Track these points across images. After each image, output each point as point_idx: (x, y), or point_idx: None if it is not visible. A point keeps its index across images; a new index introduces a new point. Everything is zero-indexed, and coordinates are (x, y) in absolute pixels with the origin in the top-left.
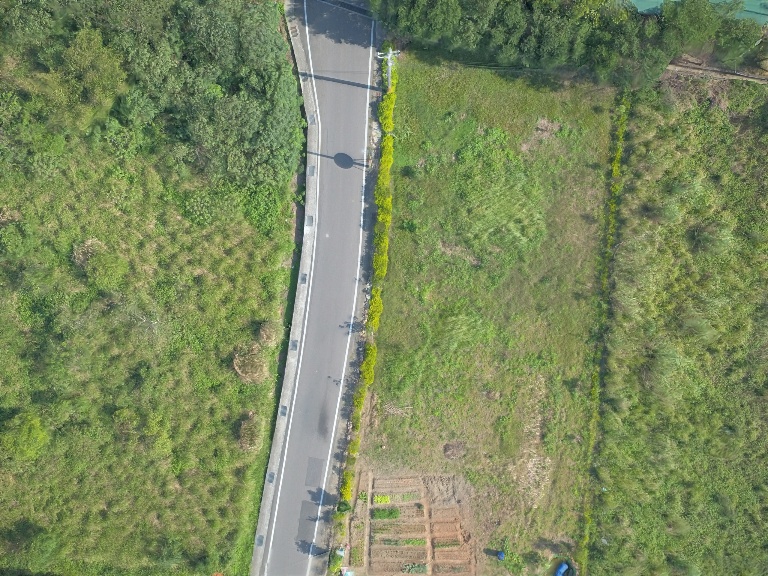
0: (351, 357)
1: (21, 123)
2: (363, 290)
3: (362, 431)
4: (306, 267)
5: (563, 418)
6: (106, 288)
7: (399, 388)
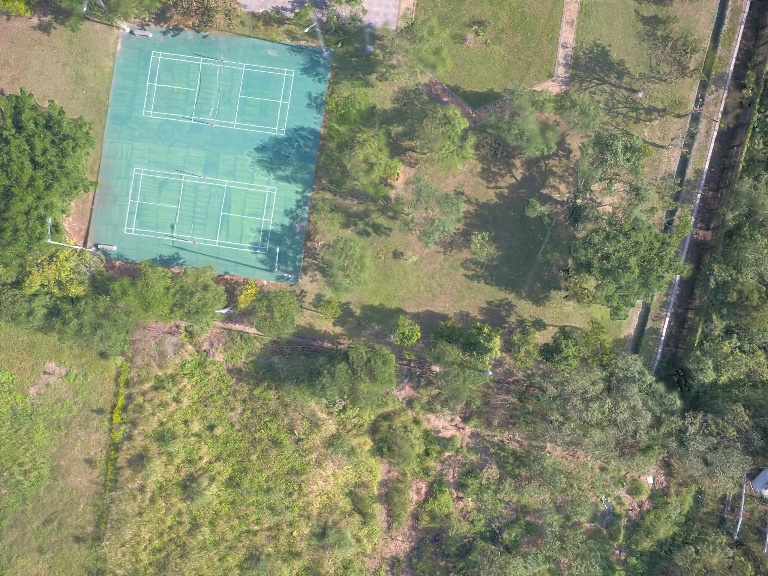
0: None
1: None
2: None
3: None
4: None
5: None
6: None
7: None
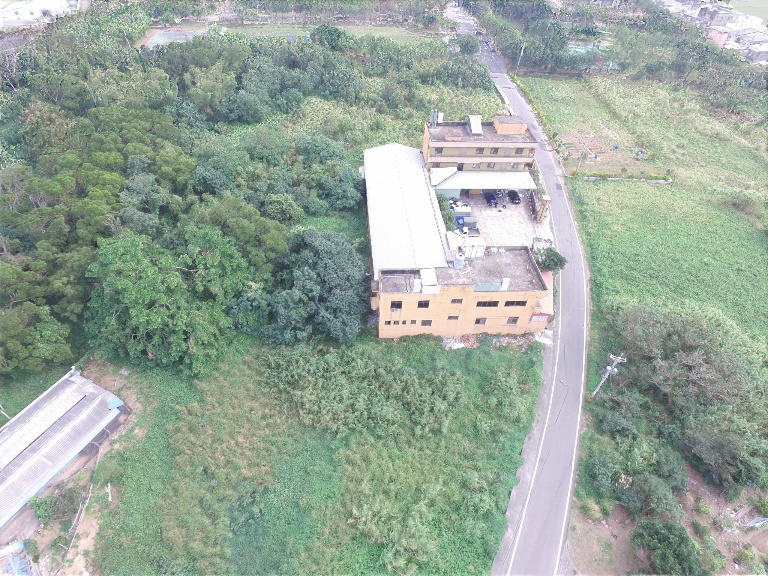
0: (534, 116)
1: None
2: None
3: None
4: (508, 103)
5: None
6: None
7: (554, 121)
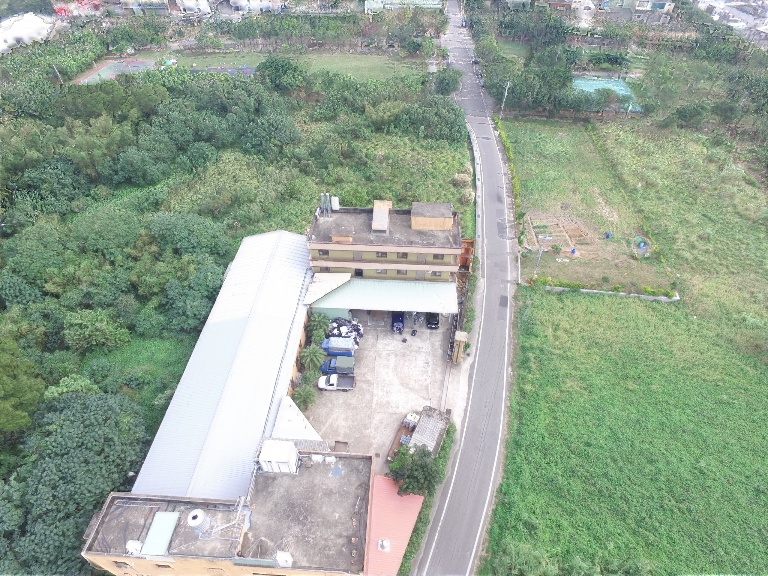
0: None
1: None
2: (505, 166)
3: None
4: (478, 161)
5: None
6: (392, 160)
7: (532, 190)
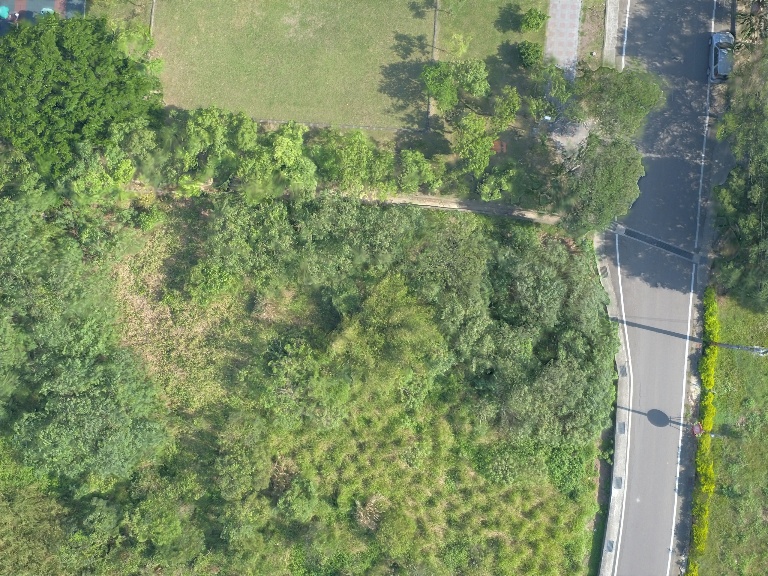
0: None
1: (312, 377)
2: (677, 562)
3: None
4: (613, 533)
5: None
6: None
7: None
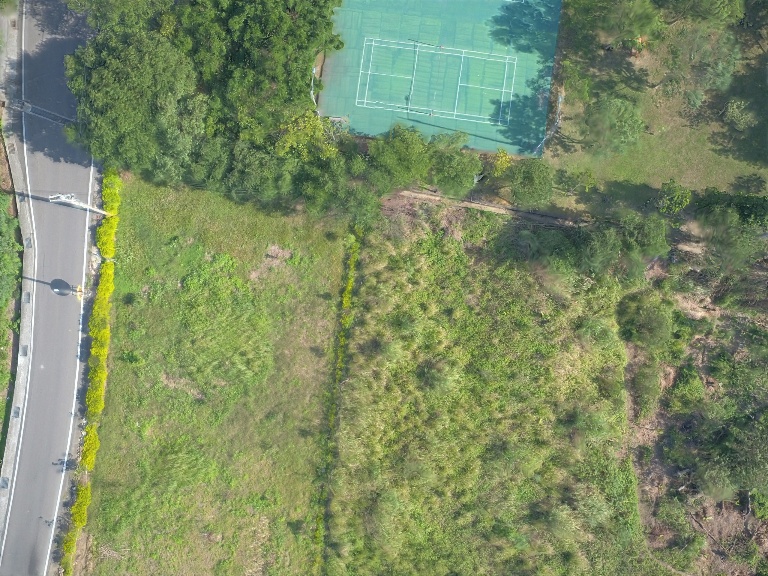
0: (65, 496)
1: None
2: (79, 425)
3: (77, 574)
4: (19, 400)
5: (287, 562)
6: None
7: (115, 530)
